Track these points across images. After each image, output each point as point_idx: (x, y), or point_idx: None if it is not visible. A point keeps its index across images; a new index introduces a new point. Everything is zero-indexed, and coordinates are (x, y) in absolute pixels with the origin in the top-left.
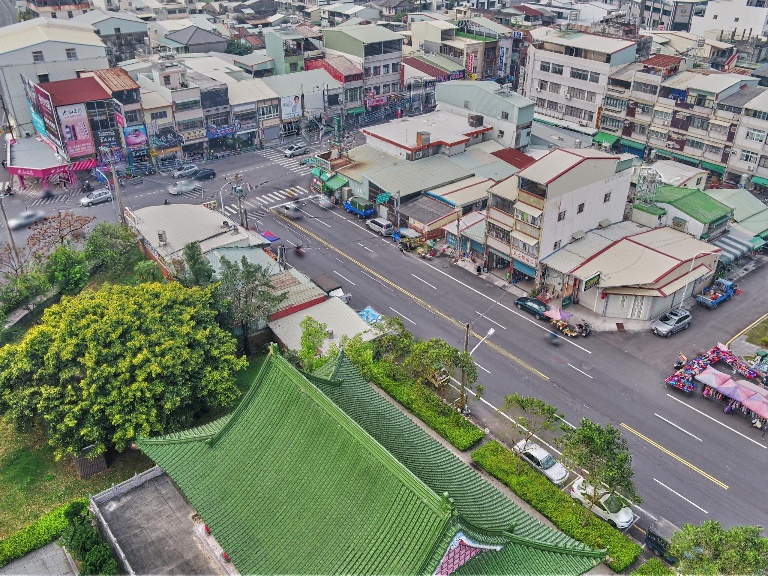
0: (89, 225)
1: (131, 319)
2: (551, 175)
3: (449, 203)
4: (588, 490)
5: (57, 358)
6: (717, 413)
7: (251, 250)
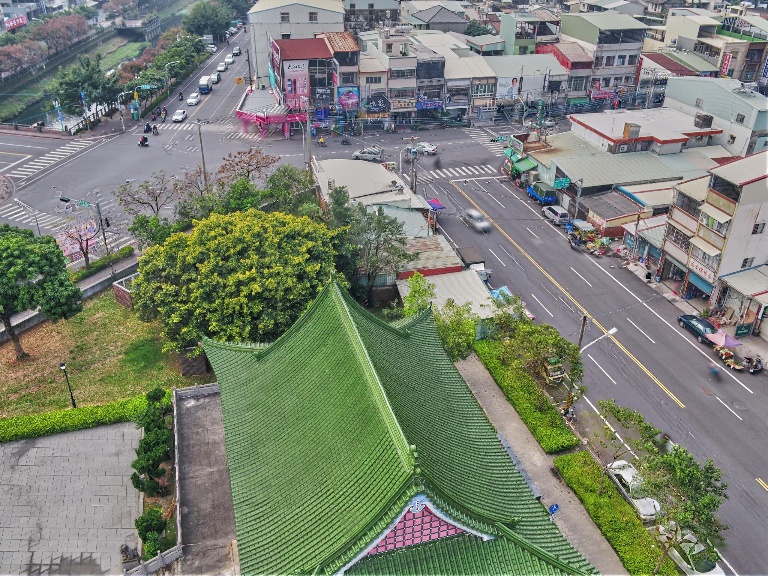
0: (274, 165)
1: (252, 239)
2: (751, 176)
3: (639, 202)
4: None
5: (184, 261)
6: None
7: (410, 212)
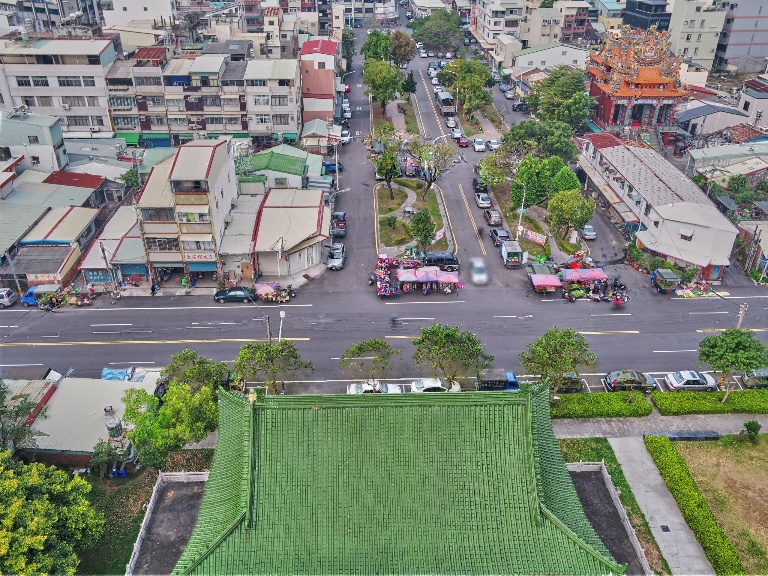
0: None
1: None
2: (202, 170)
3: (60, 243)
4: (426, 385)
5: None
6: (422, 298)
7: None
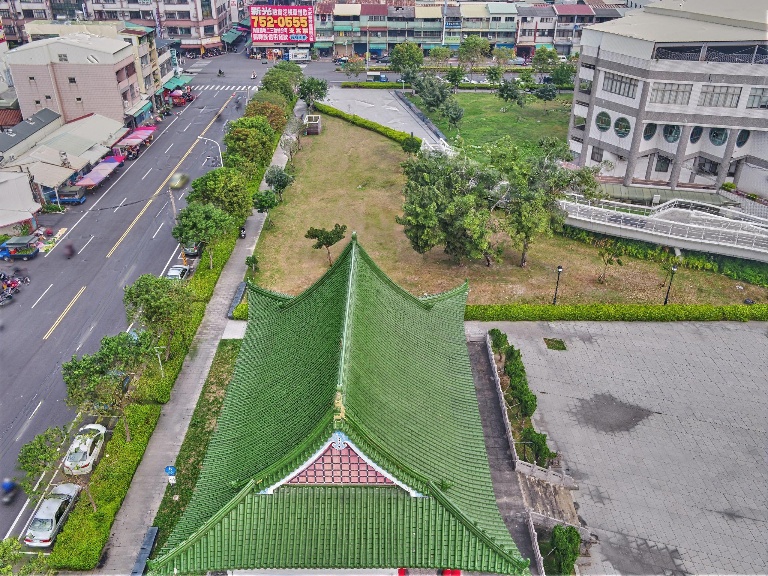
0: None
1: None
2: None
3: None
4: (86, 448)
5: None
6: None
7: None
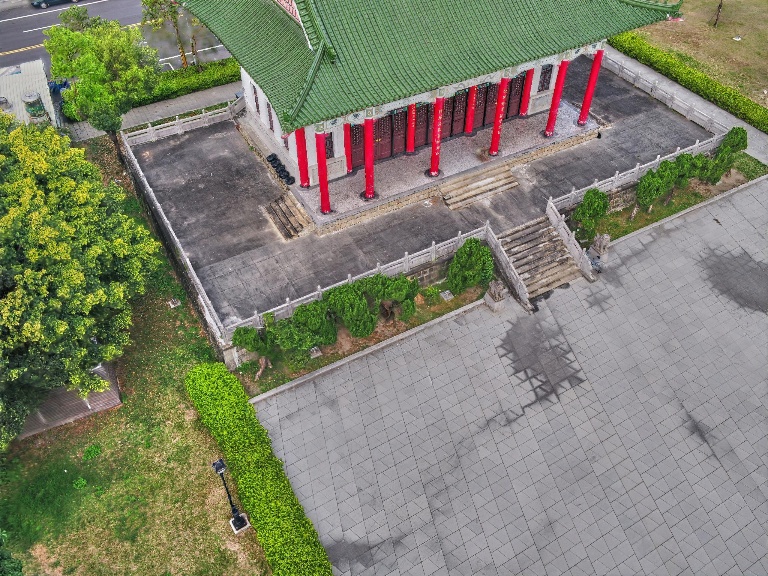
0: None
1: None
2: None
3: None
4: None
5: None
6: None
7: None
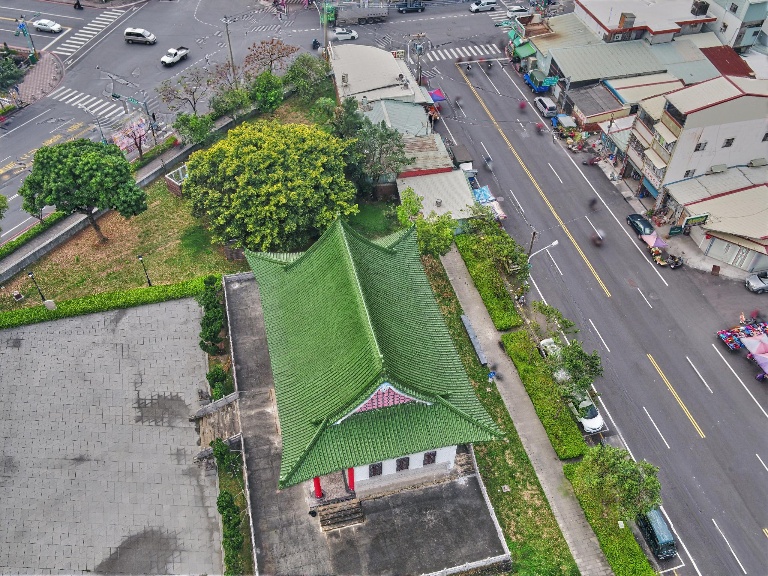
0: (294, 54)
1: (278, 156)
2: (697, 105)
3: (620, 99)
4: None
5: (224, 172)
6: (748, 376)
7: (414, 107)
